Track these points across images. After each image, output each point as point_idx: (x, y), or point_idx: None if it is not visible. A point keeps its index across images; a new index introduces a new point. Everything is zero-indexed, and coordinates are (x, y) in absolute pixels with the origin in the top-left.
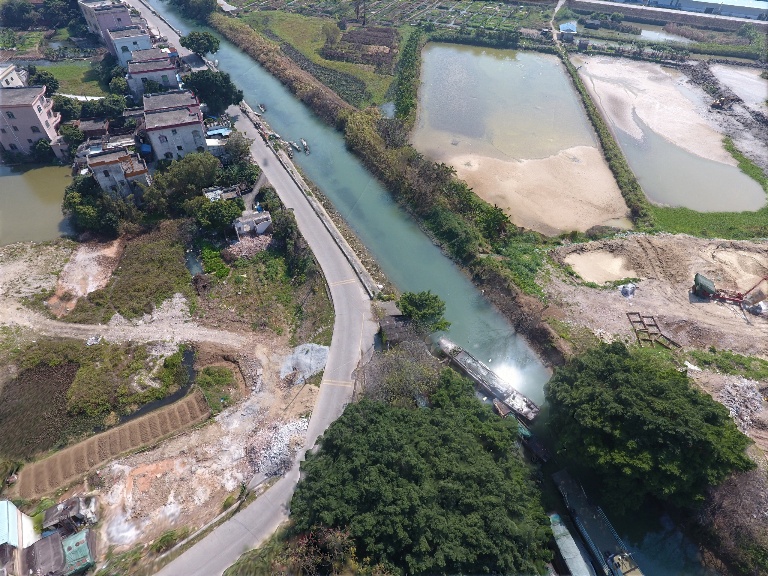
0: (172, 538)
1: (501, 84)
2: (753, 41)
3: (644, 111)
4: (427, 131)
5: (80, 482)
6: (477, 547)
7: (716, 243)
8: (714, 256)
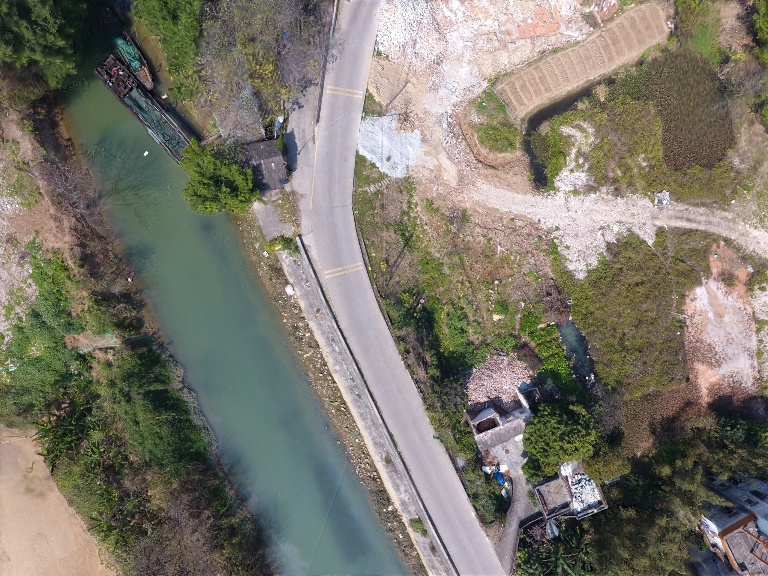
0: None
1: None
2: None
3: None
4: None
5: (605, 22)
6: None
7: None
8: None
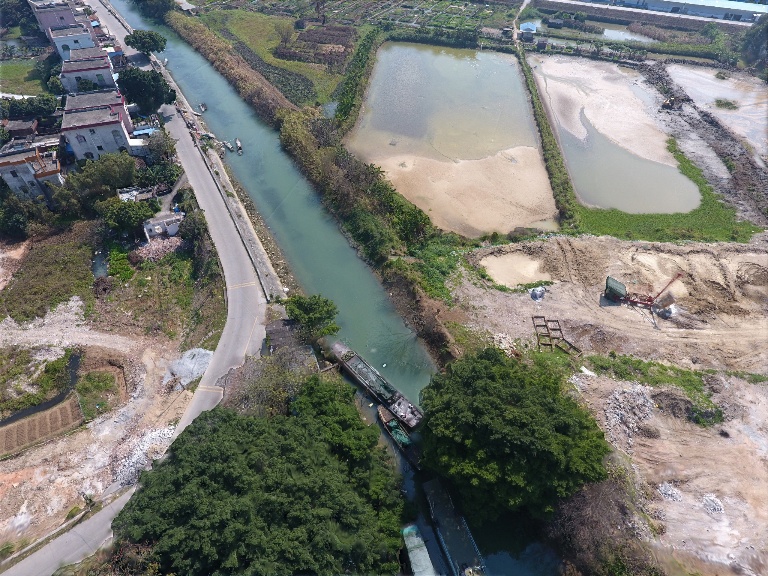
0: (7, 551)
1: (452, 84)
2: (714, 41)
3: (593, 111)
4: (367, 131)
5: None
6: (295, 562)
7: (638, 245)
8: (634, 258)
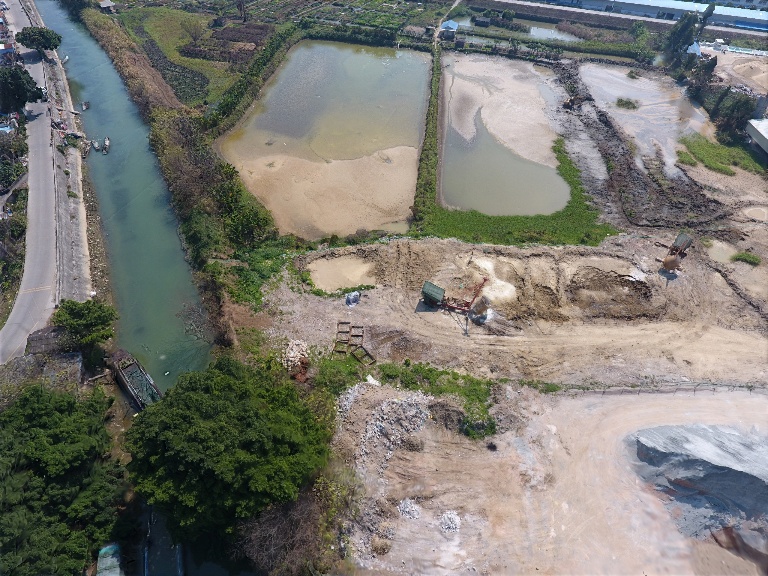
0: None
1: (356, 82)
2: (637, 39)
3: (490, 110)
4: (248, 130)
5: None
6: None
7: (479, 248)
8: (470, 262)
